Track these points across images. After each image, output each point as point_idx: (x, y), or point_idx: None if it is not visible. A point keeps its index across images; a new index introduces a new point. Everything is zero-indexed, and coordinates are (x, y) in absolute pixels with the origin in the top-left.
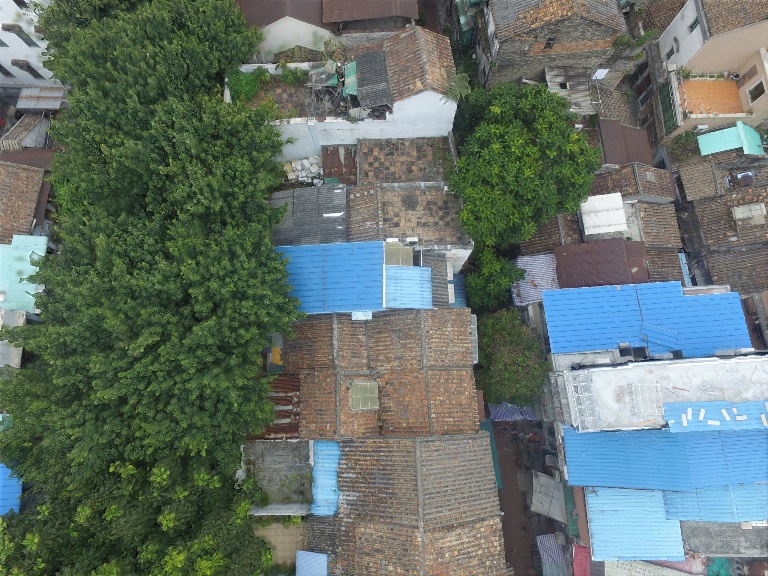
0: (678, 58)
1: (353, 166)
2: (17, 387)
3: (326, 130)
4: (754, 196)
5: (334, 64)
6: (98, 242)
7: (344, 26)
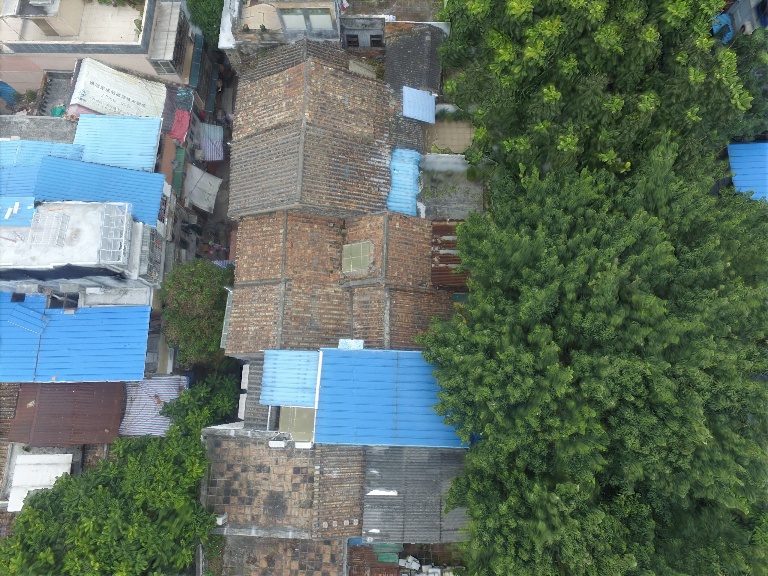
0: None
1: None
2: (767, 245)
3: None
4: None
5: None
6: None
7: None
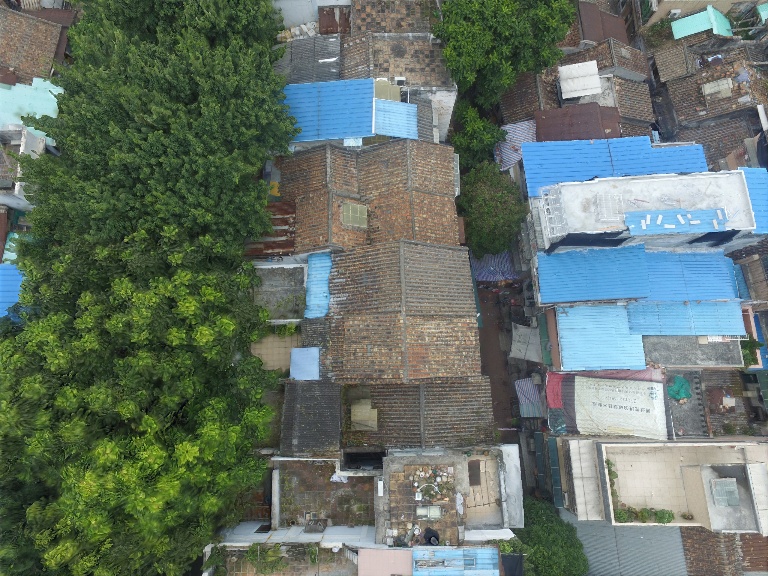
0: None
1: (347, 25)
2: (42, 162)
3: None
4: (722, 73)
5: None
6: (116, 35)
7: None
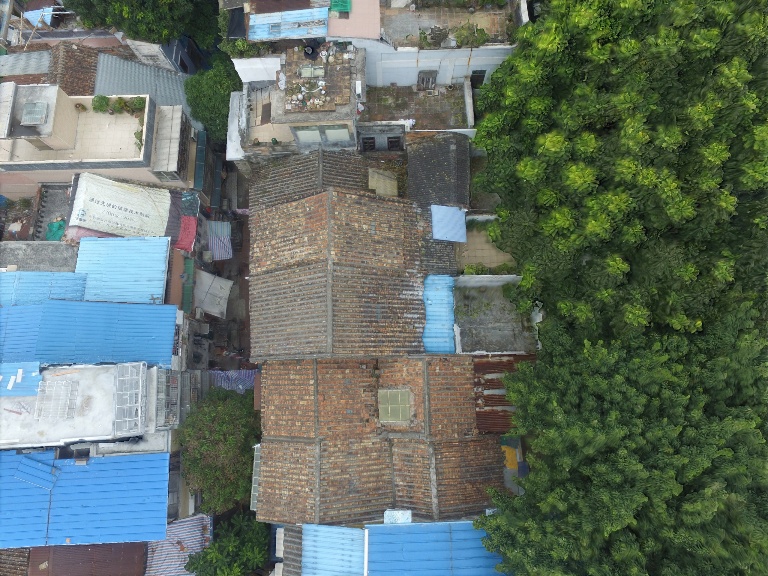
0: None
1: None
2: None
3: None
4: None
5: None
6: None
7: None
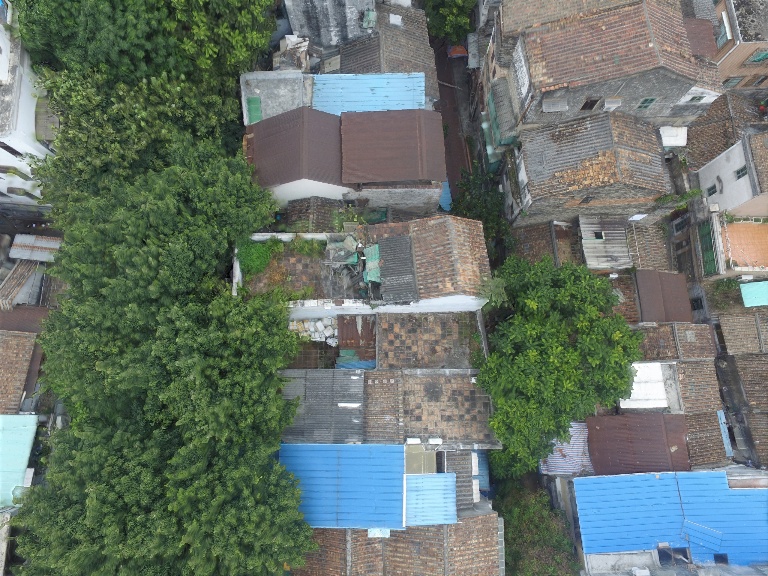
0: (721, 200)
1: (371, 338)
2: None
3: (343, 309)
4: None
5: (354, 242)
6: (88, 503)
7: (365, 183)
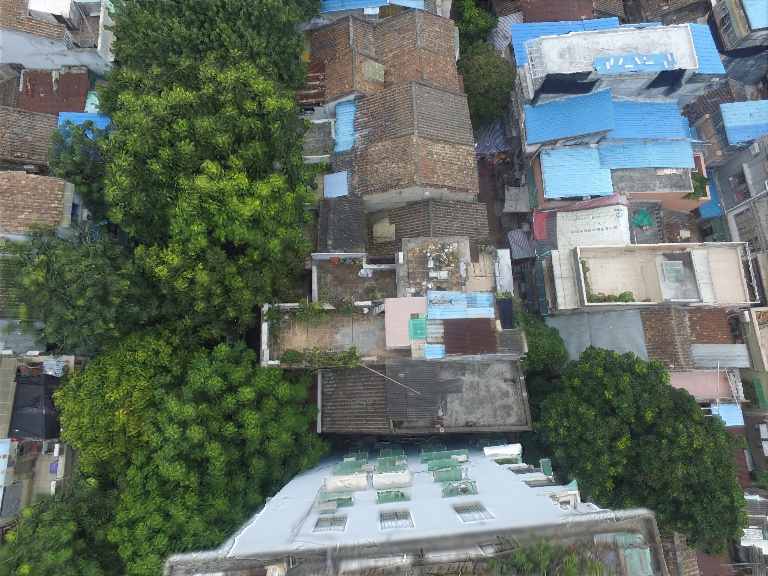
0: None
1: None
2: (131, 6)
3: None
4: None
5: None
6: None
7: None
